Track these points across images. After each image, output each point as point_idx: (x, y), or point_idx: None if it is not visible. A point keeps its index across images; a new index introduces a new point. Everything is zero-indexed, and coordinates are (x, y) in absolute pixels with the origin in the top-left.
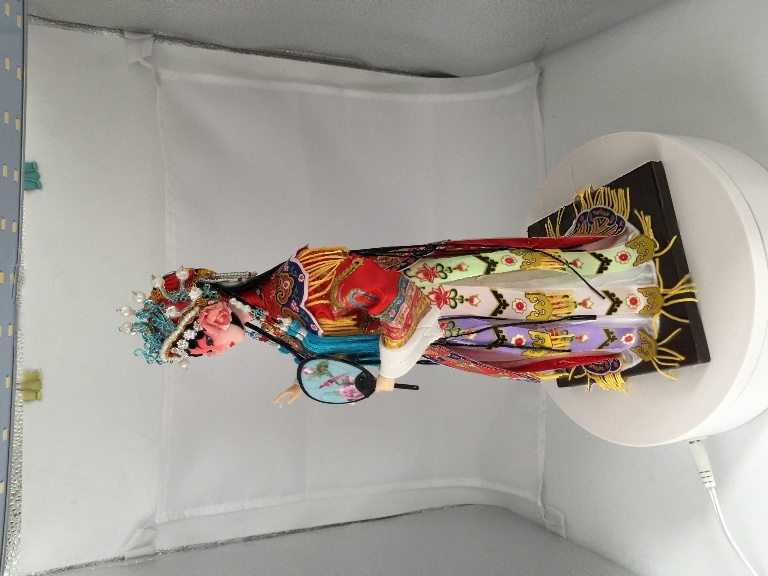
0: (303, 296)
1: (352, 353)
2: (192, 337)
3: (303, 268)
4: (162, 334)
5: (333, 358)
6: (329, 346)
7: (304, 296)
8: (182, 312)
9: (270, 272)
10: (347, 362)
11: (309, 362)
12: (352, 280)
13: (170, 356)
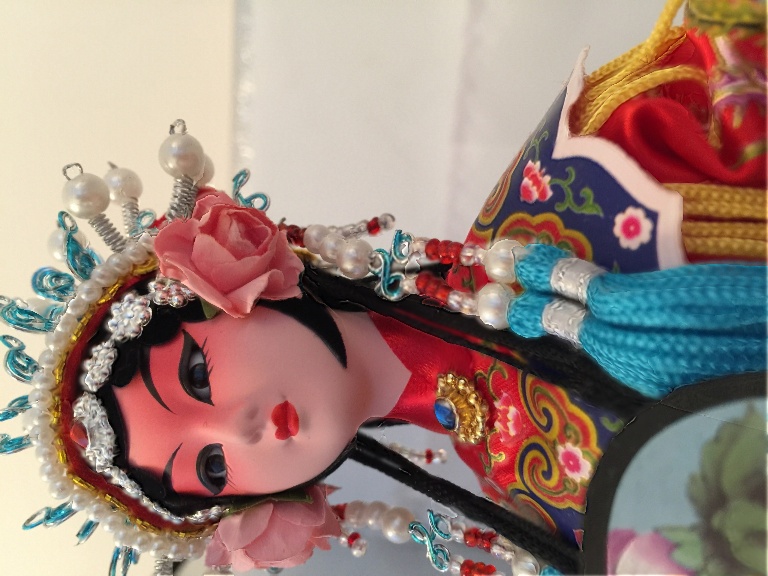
0: (562, 106)
1: None
2: (134, 328)
3: None
4: None
5: None
6: (741, 296)
7: (565, 102)
8: None
9: None
10: None
11: (635, 467)
12: None
13: (80, 474)
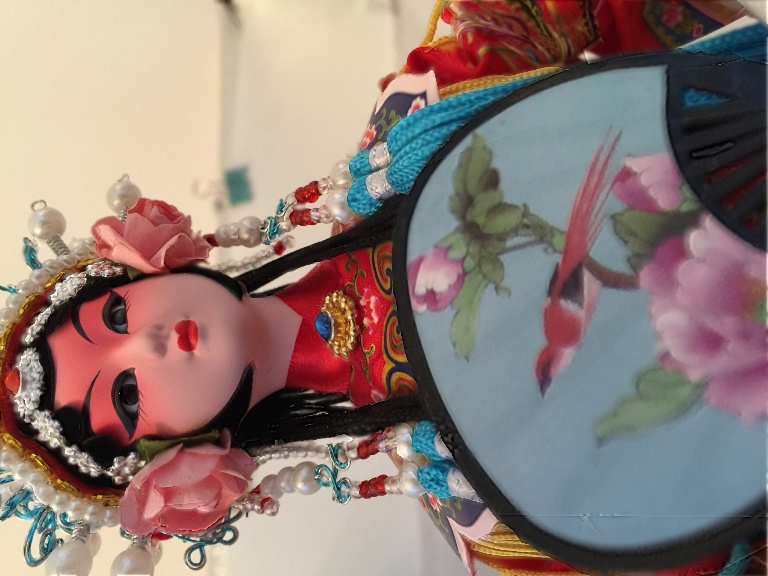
0: None
1: None
2: (71, 293)
3: None
4: None
5: (492, 108)
6: (467, 96)
7: None
8: None
9: None
10: (558, 77)
11: (417, 214)
12: None
13: (10, 432)
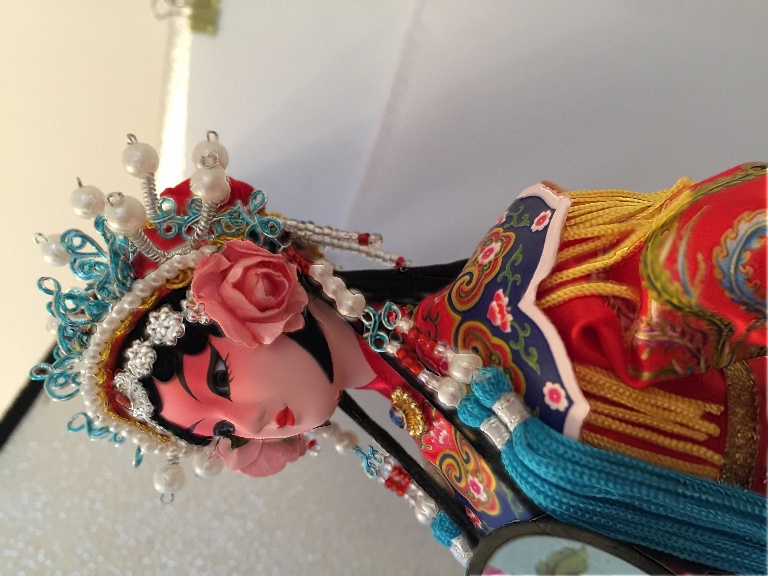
0: (536, 266)
1: (684, 558)
2: (170, 337)
3: (553, 195)
4: (101, 312)
5: (608, 541)
6: (600, 483)
7: (540, 265)
8: (169, 254)
9: (454, 270)
10: (665, 575)
11: (511, 543)
12: (744, 191)
13: (118, 411)
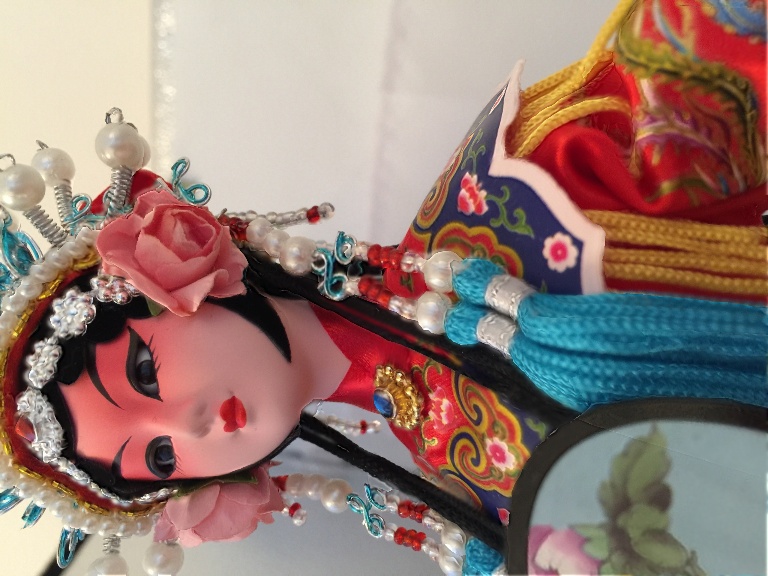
0: (498, 123)
1: None
2: (78, 325)
3: None
4: None
5: (688, 403)
6: (650, 328)
7: (502, 119)
8: None
9: None
10: None
11: (555, 472)
12: None
13: (26, 463)
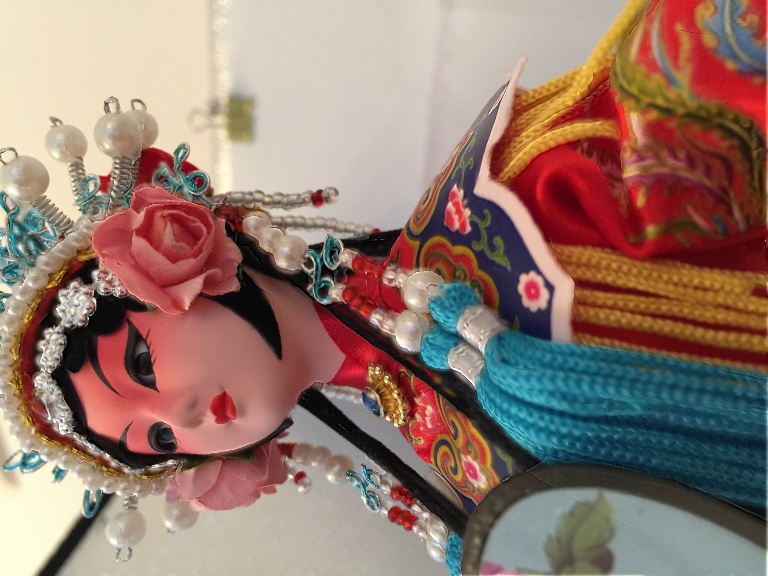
0: (488, 136)
1: None
2: (81, 316)
3: None
4: None
5: (635, 477)
6: (609, 391)
7: (491, 133)
8: None
9: None
10: (734, 516)
11: (505, 517)
12: None
13: (47, 433)
